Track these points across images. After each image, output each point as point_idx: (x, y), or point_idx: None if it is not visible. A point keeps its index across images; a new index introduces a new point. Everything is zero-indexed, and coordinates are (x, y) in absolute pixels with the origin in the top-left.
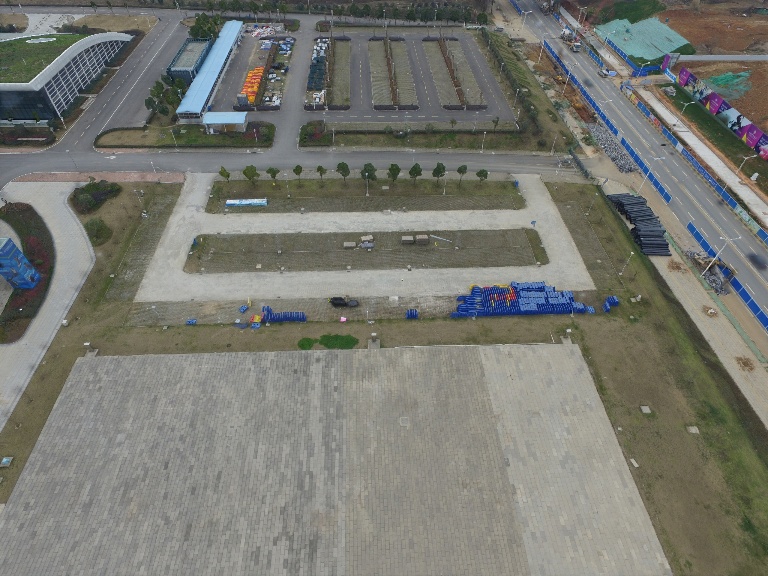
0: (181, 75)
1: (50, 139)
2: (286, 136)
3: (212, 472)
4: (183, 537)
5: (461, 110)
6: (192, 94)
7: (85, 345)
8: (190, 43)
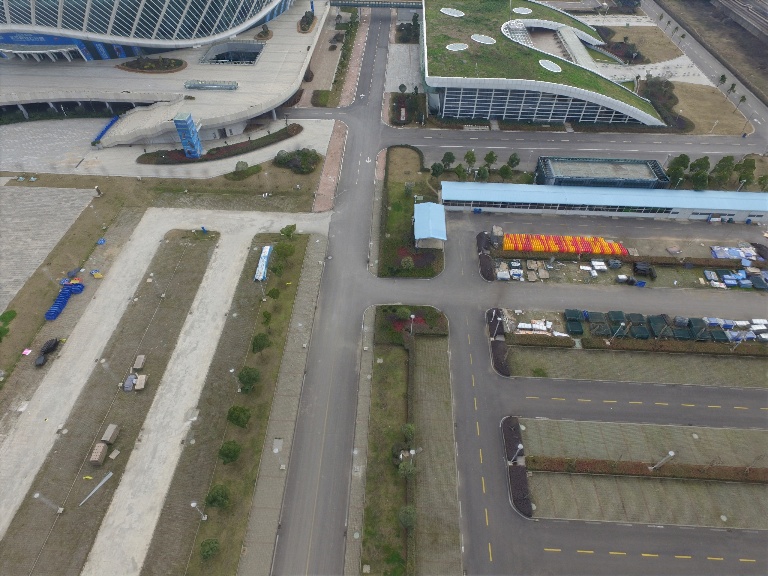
0: None
1: (400, 122)
2: (407, 290)
3: None
4: None
5: None
6: (488, 187)
7: None
8: (644, 165)
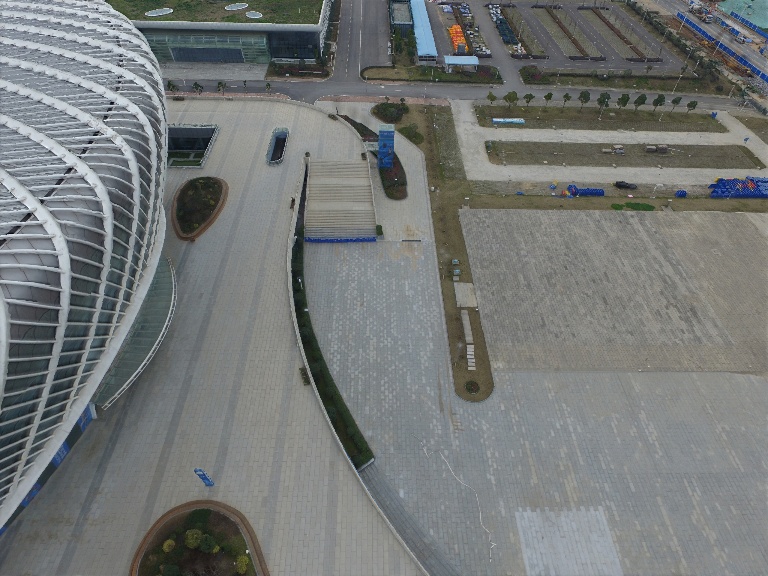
0: (403, 28)
1: (326, 72)
2: (510, 76)
3: (600, 272)
4: (604, 303)
5: (642, 62)
6: (423, 42)
7: (466, 199)
8: (394, 4)
